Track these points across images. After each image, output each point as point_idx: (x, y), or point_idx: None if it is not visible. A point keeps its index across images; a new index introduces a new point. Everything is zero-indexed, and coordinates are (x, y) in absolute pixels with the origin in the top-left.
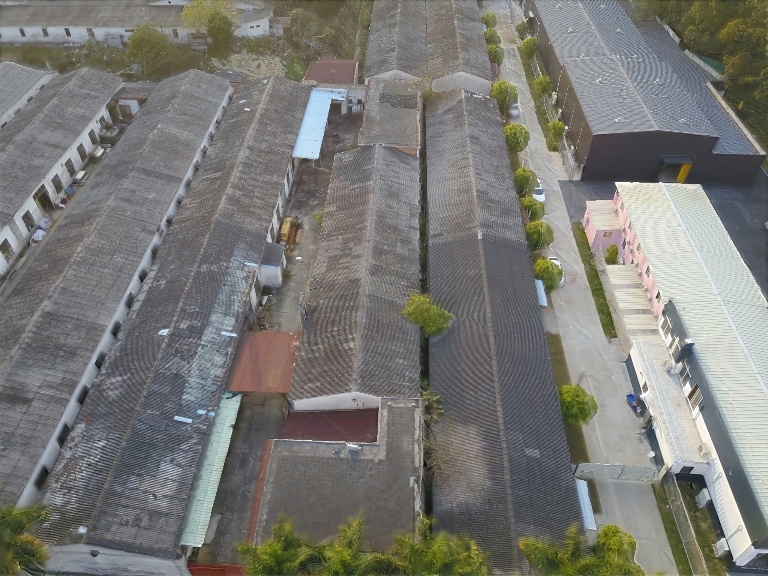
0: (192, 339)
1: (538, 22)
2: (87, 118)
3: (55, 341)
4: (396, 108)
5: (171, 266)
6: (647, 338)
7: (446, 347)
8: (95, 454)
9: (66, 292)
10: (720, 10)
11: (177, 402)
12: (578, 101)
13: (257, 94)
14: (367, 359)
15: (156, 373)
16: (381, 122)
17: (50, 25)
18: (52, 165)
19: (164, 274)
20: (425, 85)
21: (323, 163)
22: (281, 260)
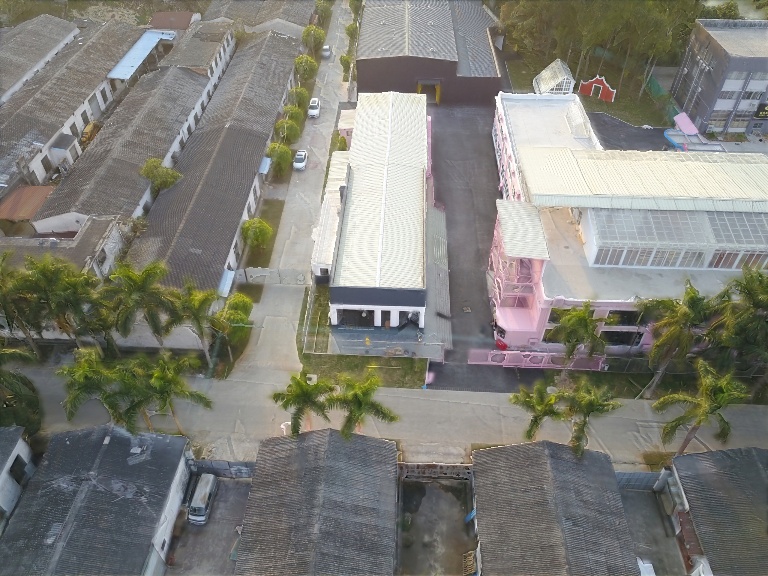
0: None
1: None
2: None
3: None
4: (203, 42)
5: None
6: None
7: (168, 195)
8: None
9: None
10: None
11: None
12: (359, 37)
13: (93, 33)
14: (93, 195)
15: None
16: (185, 51)
17: None
18: None
19: None
20: (238, 26)
21: None
22: (71, 146)
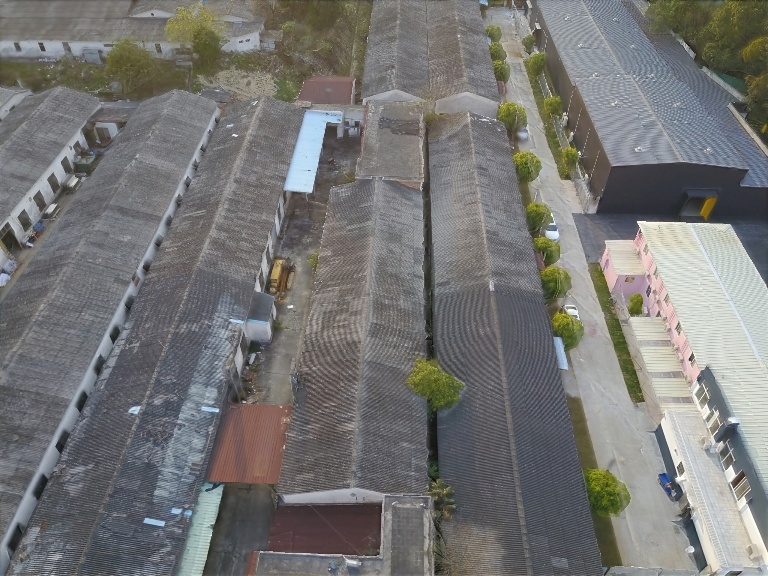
0: (167, 418)
1: (546, 35)
2: (59, 145)
3: (9, 422)
4: (397, 135)
5: (146, 325)
6: (680, 407)
7: (457, 423)
8: (49, 570)
9: (25, 360)
10: (742, 26)
11: (148, 500)
12: (593, 127)
13: (246, 118)
14: (368, 444)
15: (124, 463)
16: (381, 151)
17: (23, 39)
18: (18, 200)
19: (138, 334)
20: (428, 108)
21: (317, 194)
22: (271, 313)
